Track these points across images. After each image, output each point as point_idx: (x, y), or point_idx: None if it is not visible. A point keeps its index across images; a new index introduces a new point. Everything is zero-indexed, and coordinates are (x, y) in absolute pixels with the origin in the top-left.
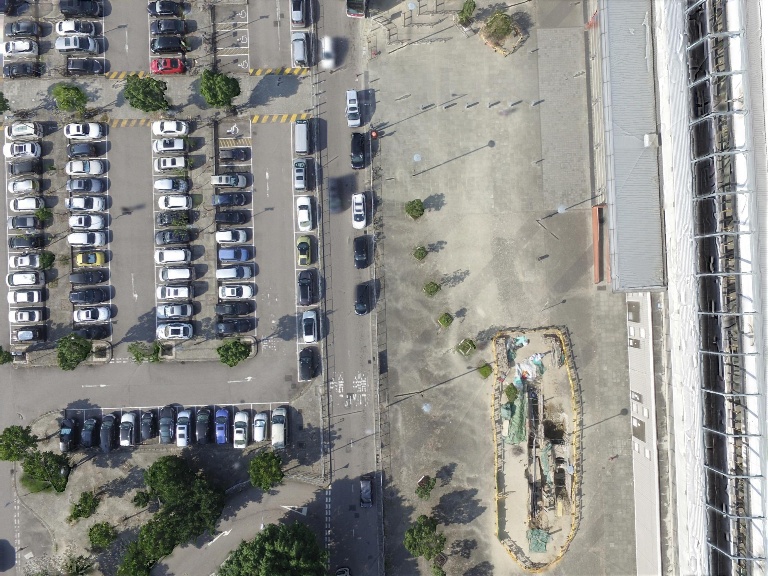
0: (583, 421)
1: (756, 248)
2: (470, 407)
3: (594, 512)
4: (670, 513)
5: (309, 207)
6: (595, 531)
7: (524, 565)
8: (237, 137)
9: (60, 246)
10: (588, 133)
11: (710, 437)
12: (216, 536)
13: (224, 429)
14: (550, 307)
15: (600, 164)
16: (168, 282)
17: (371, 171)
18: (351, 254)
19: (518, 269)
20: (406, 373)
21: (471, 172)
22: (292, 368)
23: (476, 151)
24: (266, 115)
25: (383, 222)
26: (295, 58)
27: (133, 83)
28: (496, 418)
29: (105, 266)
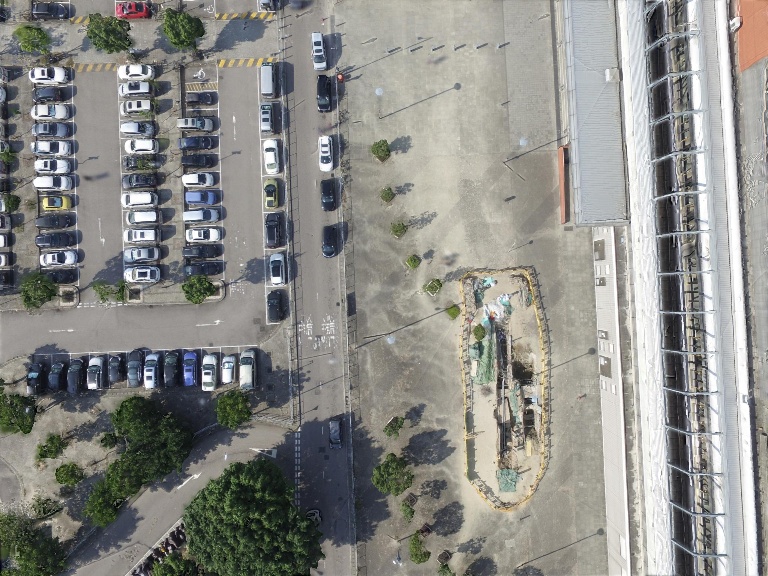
0: (551, 361)
1: (710, 167)
2: (439, 348)
3: (563, 451)
4: (636, 446)
5: (276, 149)
6: (564, 470)
7: (494, 505)
8: (204, 81)
9: (26, 191)
10: (553, 75)
11: (672, 366)
12: (185, 479)
13: (192, 371)
14: (517, 248)
15: (565, 106)
16: (135, 226)
17: (337, 113)
18: (318, 197)
19: (485, 210)
20: (374, 315)
21: (437, 114)
22: (260, 311)
23: (442, 94)
24: (232, 59)
25: (350, 165)
26: (260, 1)
27: (95, 21)
28: (465, 359)
29: (72, 211)
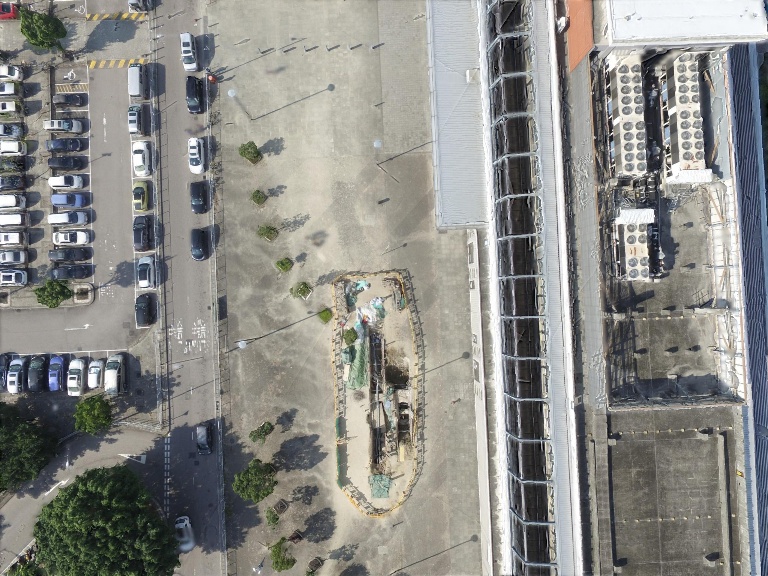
0: (425, 365)
1: None
2: (311, 352)
3: (437, 456)
4: None
5: (144, 151)
6: (438, 476)
7: (366, 511)
8: (74, 83)
9: None
10: None
11: (528, 371)
12: (53, 486)
13: (57, 376)
14: (391, 251)
15: None
16: (2, 229)
17: (207, 115)
18: (189, 199)
19: (359, 213)
20: (246, 319)
21: (311, 116)
22: (130, 315)
23: (316, 95)
24: (103, 60)
25: (222, 167)
26: (128, 1)
27: None
28: (337, 363)
29: None
